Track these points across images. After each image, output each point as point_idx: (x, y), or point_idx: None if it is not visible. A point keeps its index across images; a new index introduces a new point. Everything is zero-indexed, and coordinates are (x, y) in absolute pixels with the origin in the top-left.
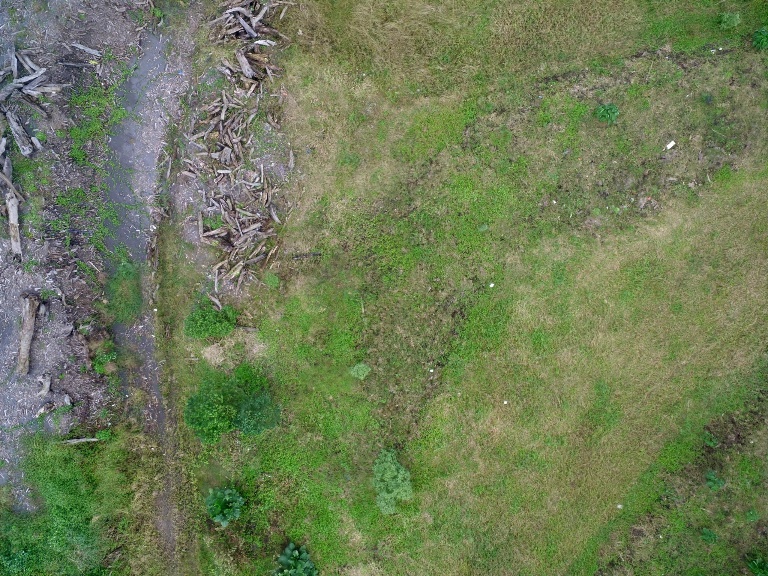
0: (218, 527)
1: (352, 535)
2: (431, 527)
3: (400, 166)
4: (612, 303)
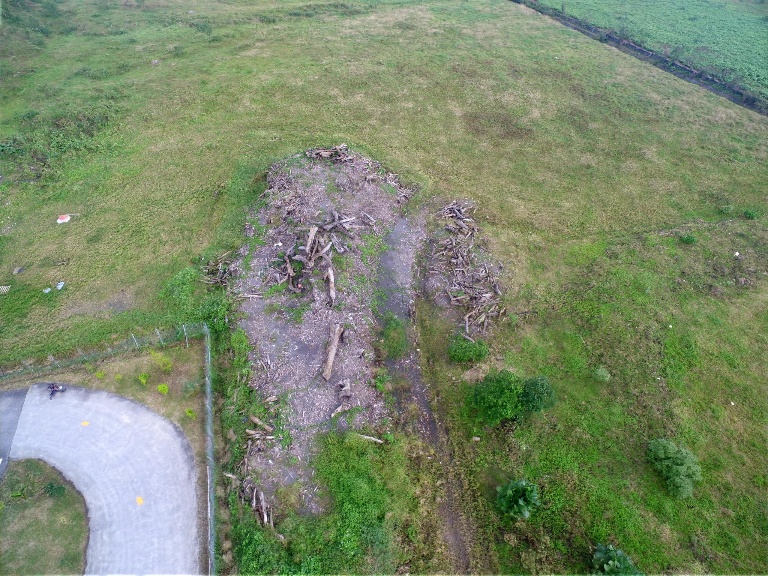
0: (518, 522)
1: (660, 529)
2: (735, 521)
3: (572, 268)
4: (765, 336)
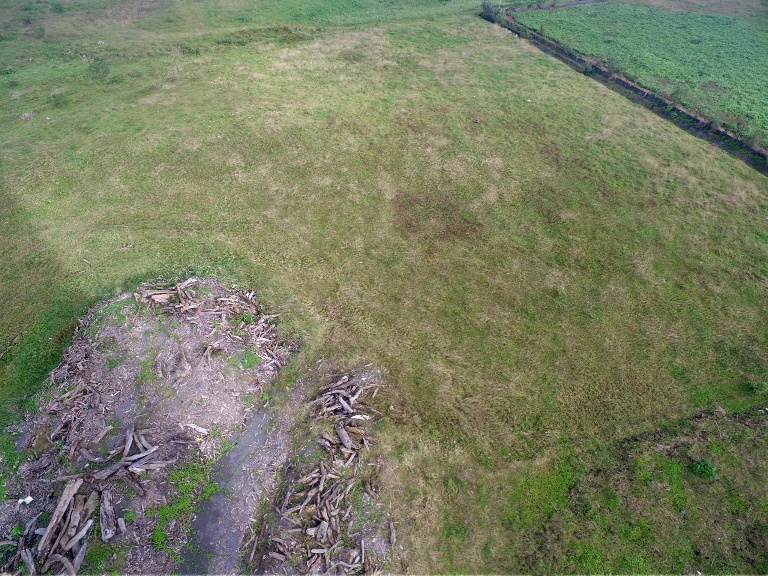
0: None
1: None
2: None
3: (511, 536)
4: None
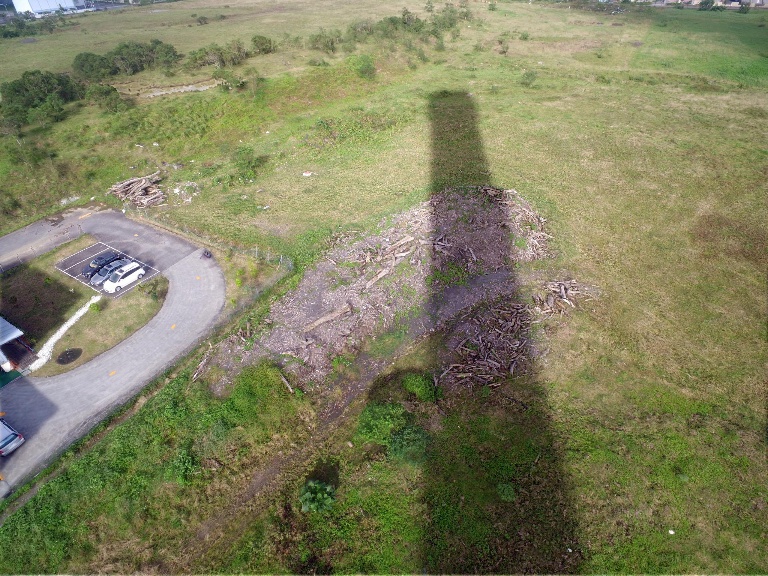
0: (296, 508)
1: None
2: None
3: (625, 402)
4: None
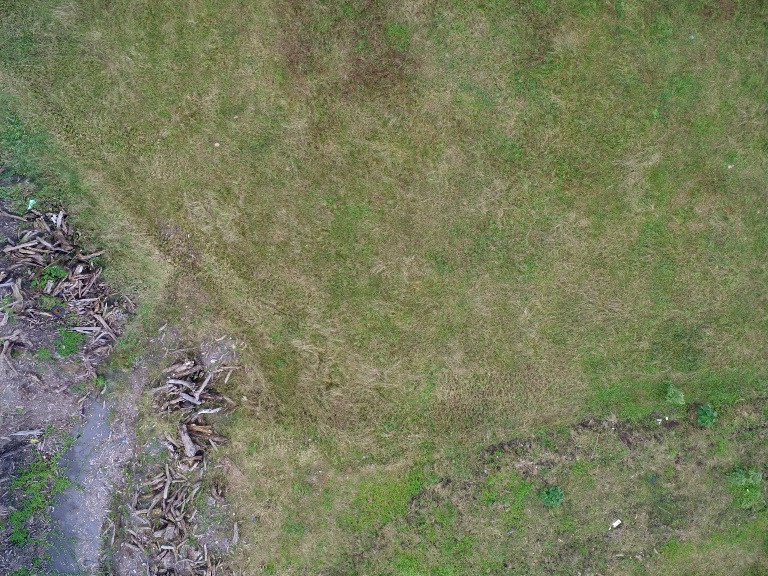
0: None
1: None
2: None
3: (346, 536)
4: None
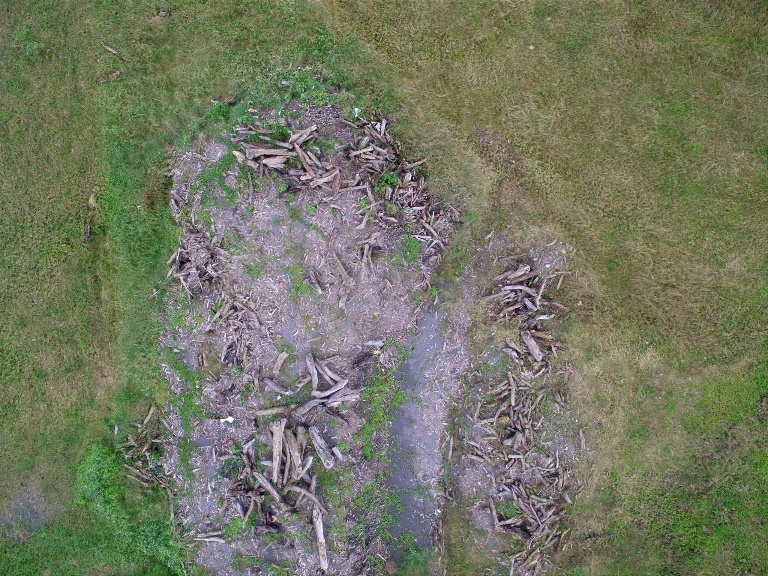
0: None
1: None
2: None
3: (692, 439)
4: None
